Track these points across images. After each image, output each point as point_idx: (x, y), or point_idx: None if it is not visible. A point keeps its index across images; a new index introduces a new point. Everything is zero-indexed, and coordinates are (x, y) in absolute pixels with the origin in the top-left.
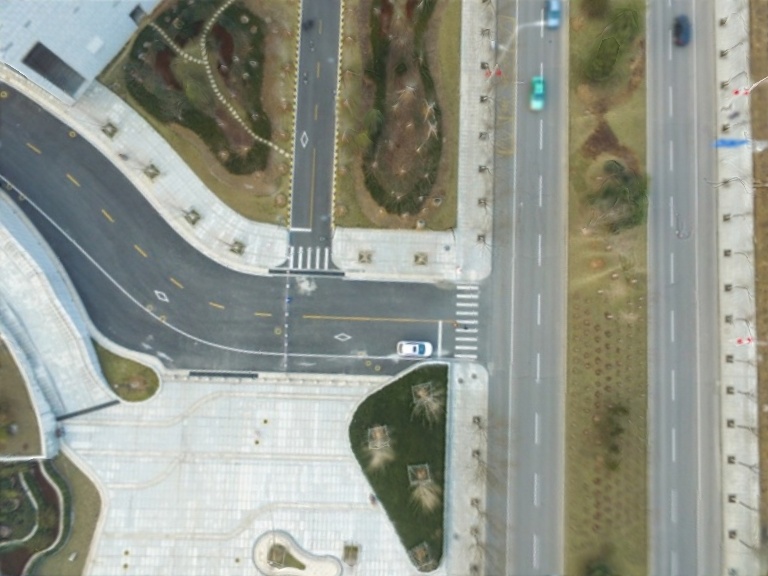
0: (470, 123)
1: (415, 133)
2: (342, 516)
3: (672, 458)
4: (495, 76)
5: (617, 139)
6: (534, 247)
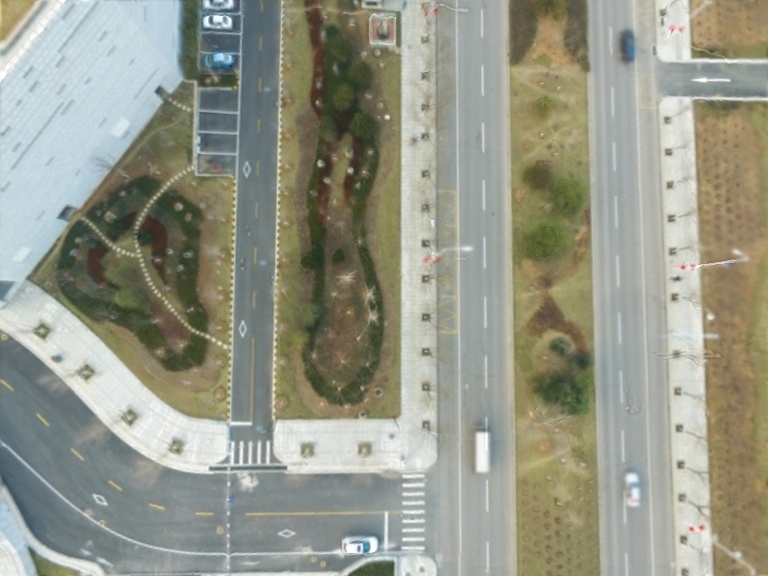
0: (412, 304)
1: (355, 320)
2: None
3: None
4: (433, 264)
5: (563, 315)
6: (481, 430)
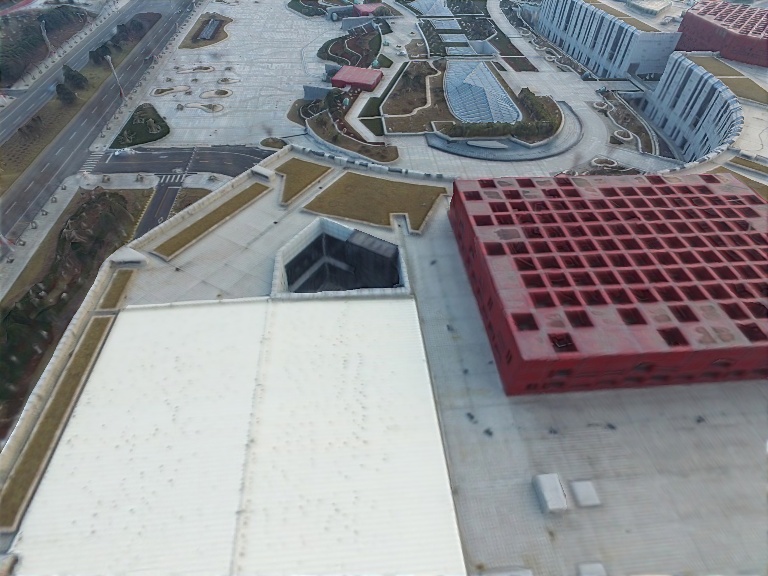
0: (41, 233)
1: None
2: None
3: (6, 130)
4: None
5: None
6: None
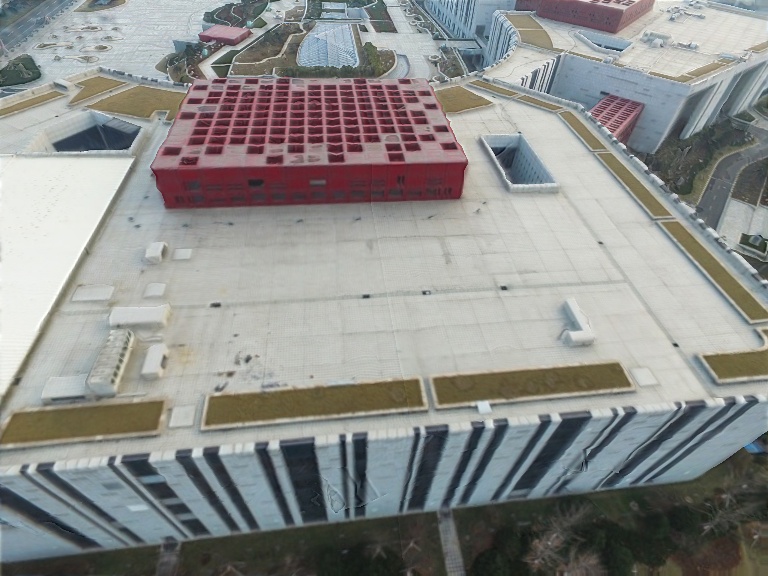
0: None
1: None
2: (56, 65)
3: None
4: None
5: None
6: None
